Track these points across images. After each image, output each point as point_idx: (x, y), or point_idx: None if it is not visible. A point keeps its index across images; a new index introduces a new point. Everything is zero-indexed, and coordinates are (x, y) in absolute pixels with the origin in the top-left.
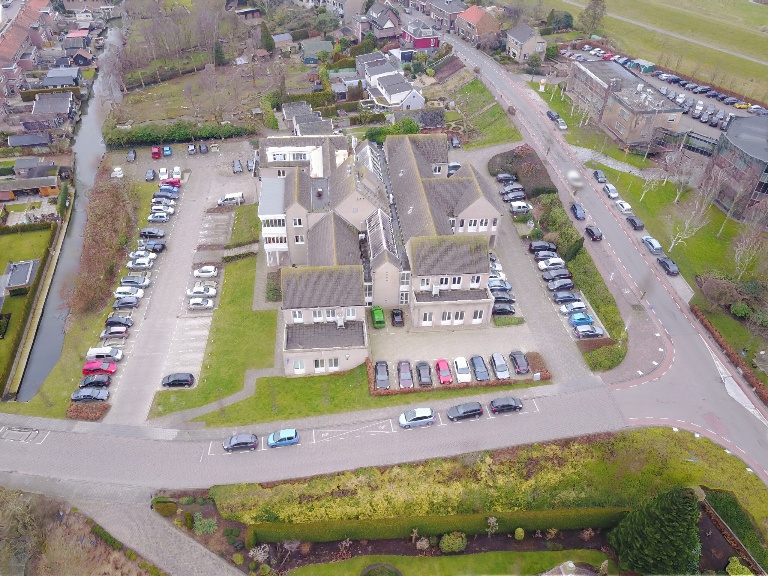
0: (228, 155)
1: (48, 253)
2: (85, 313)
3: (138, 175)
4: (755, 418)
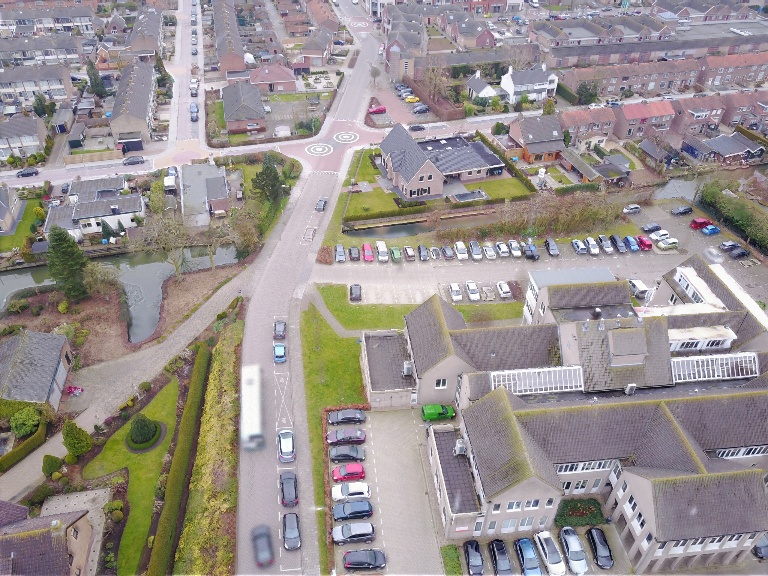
0: (743, 275)
1: (500, 202)
2: (436, 237)
3: (650, 222)
4: None
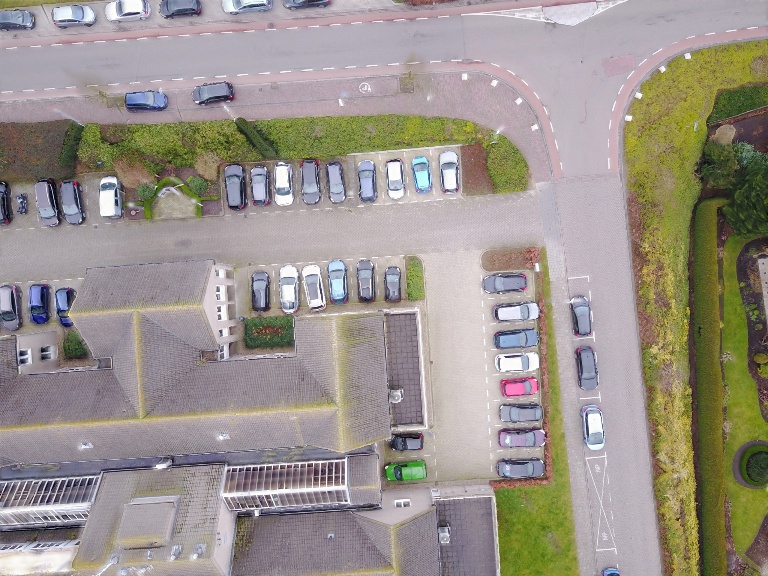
0: None
1: None
2: None
3: None
4: (613, 11)
